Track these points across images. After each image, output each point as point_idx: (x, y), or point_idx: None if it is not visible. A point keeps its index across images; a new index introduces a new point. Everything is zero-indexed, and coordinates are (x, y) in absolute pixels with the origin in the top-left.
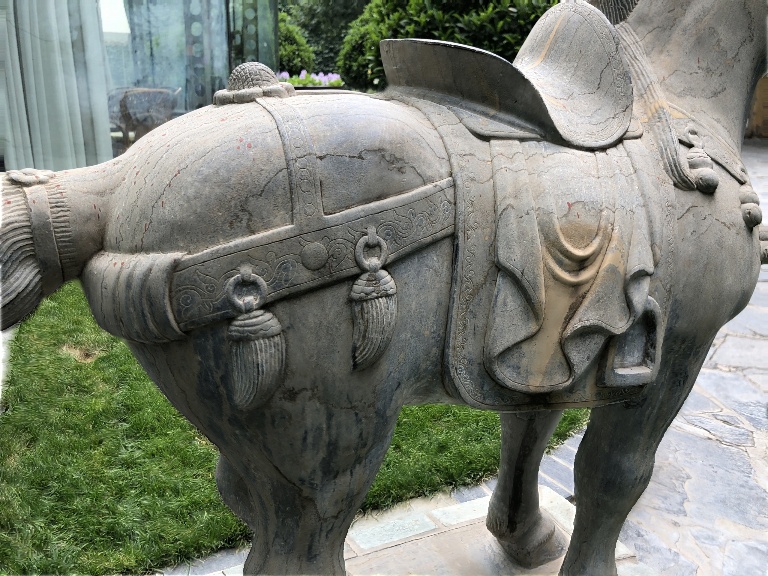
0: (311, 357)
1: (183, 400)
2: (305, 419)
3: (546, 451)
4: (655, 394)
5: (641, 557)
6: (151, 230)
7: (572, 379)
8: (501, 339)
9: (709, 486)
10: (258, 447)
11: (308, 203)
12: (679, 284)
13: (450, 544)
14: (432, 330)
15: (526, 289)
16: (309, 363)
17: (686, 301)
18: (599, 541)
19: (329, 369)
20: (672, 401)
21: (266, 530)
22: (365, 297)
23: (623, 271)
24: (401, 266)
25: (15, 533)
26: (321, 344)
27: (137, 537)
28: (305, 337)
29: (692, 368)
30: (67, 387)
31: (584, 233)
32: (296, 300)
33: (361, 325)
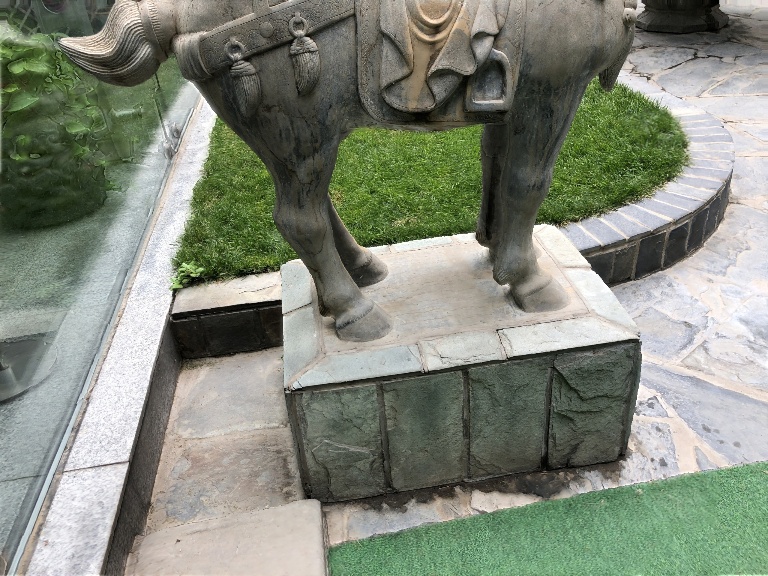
0: (274, 87)
1: (220, 112)
2: (278, 123)
3: (597, 215)
4: (530, 124)
5: (662, 300)
6: (189, 20)
7: (435, 104)
8: (385, 78)
9: (764, 257)
10: (259, 139)
11: (260, 0)
12: (529, 42)
13: (455, 251)
14: (348, 74)
15: (398, 47)
16: (274, 91)
17: (536, 54)
18: (514, 231)
19: (285, 94)
20: (545, 129)
21: (277, 191)
22: (297, 53)
23: (469, 33)
24: (320, 35)
25: (206, 244)
26: (278, 80)
27: (276, 250)
28: (269, 76)
29: (556, 105)
30: (244, 162)
31: (438, 9)
32: (261, 55)
33: (298, 69)
